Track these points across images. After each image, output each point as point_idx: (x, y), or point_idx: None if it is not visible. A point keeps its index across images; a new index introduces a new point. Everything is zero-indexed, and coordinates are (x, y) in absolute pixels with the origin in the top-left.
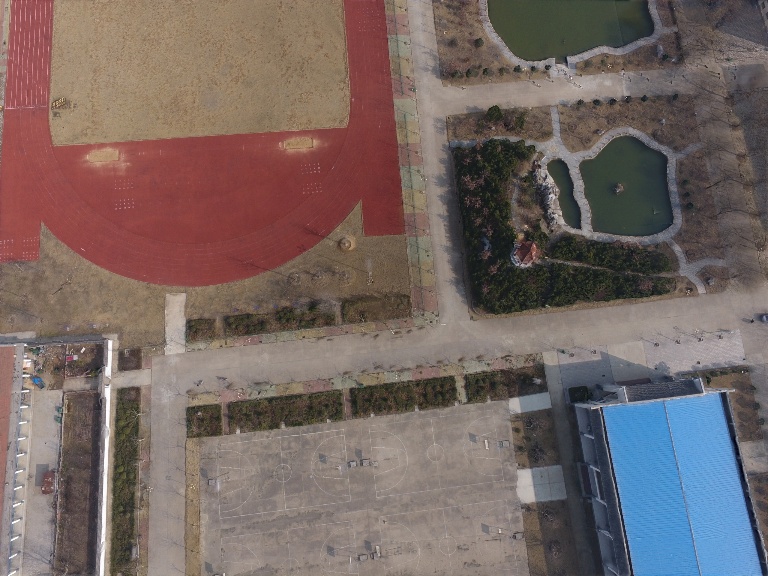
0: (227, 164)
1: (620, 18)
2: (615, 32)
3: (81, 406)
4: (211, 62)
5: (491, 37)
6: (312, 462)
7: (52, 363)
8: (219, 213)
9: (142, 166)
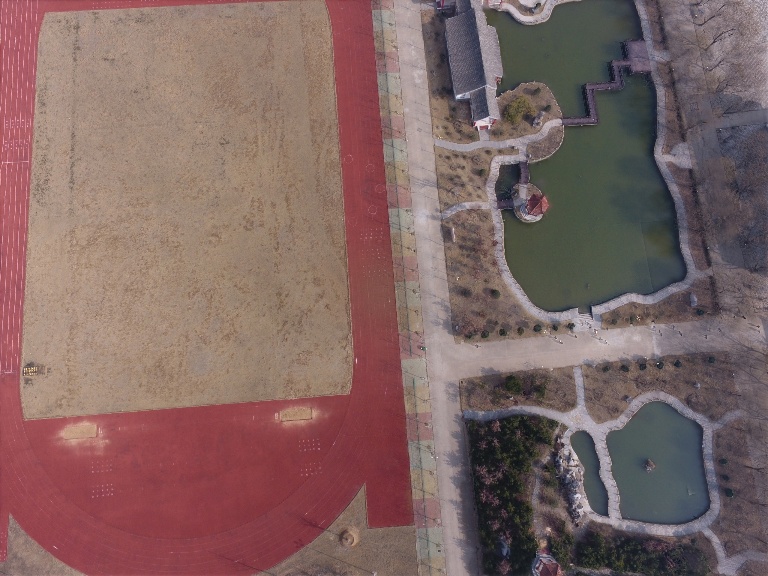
0: (217, 440)
1: (649, 258)
2: (644, 275)
3: None
4: (200, 316)
5: (508, 283)
6: None
7: None
8: (207, 501)
9: (122, 444)
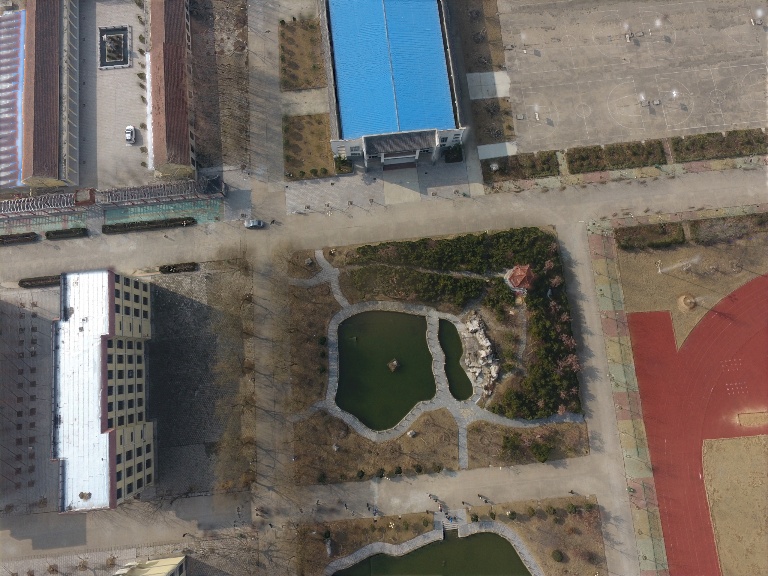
0: None
1: None
2: None
3: None
4: None
5: (538, 568)
6: (693, 105)
7: None
8: None
9: None
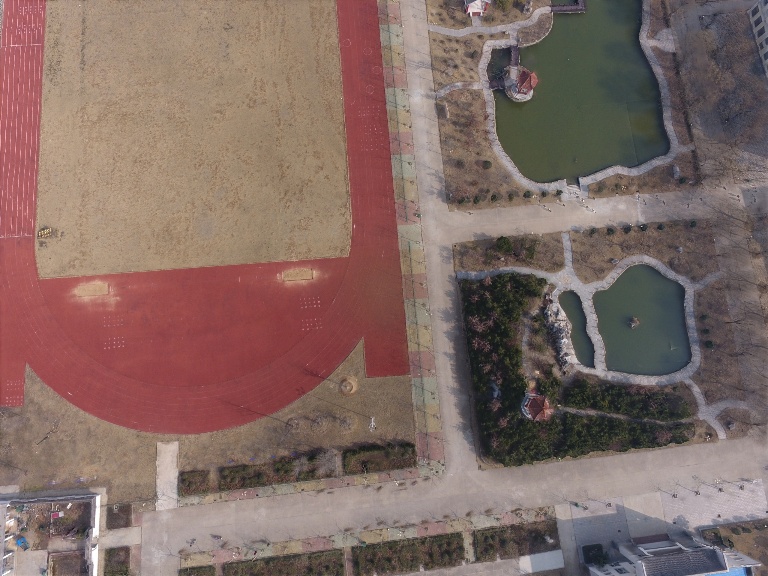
0: (222, 298)
1: (634, 134)
2: (629, 150)
3: (67, 568)
4: (206, 185)
5: (499, 157)
6: None
7: (36, 520)
8: (214, 352)
9: (133, 301)
